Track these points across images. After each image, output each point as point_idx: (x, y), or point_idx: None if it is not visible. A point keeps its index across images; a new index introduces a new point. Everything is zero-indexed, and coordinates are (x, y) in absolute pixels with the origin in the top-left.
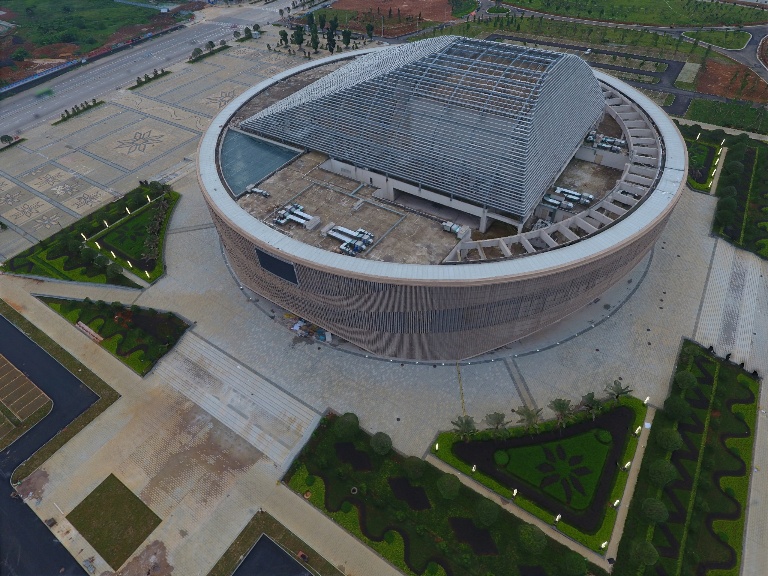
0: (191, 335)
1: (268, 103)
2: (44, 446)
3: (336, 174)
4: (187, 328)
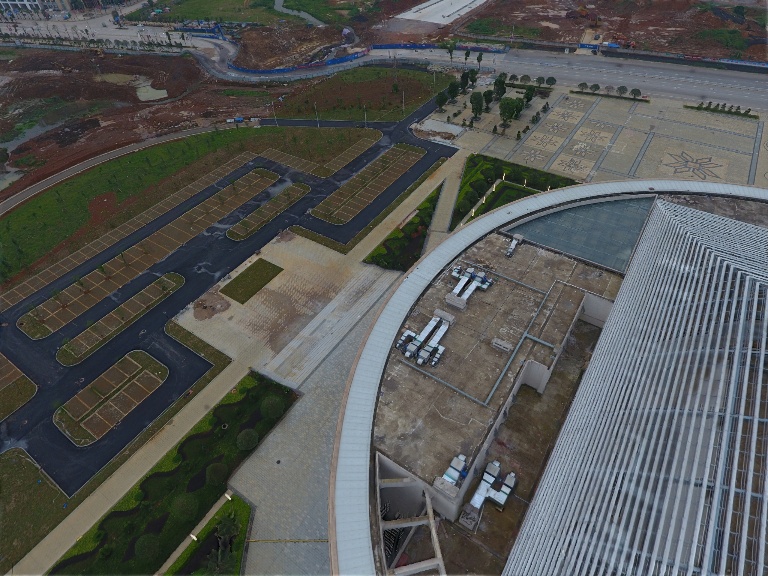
0: (396, 276)
1: (753, 218)
2: (311, 231)
3: (576, 314)
4: (403, 271)
